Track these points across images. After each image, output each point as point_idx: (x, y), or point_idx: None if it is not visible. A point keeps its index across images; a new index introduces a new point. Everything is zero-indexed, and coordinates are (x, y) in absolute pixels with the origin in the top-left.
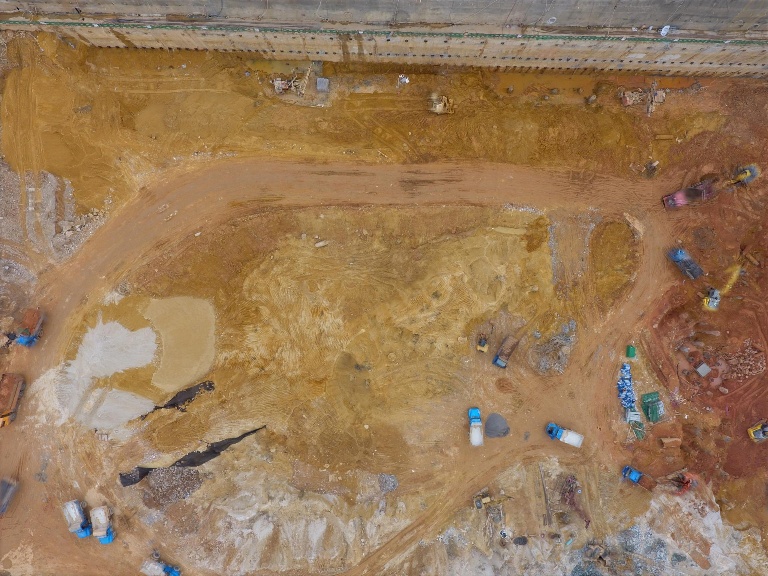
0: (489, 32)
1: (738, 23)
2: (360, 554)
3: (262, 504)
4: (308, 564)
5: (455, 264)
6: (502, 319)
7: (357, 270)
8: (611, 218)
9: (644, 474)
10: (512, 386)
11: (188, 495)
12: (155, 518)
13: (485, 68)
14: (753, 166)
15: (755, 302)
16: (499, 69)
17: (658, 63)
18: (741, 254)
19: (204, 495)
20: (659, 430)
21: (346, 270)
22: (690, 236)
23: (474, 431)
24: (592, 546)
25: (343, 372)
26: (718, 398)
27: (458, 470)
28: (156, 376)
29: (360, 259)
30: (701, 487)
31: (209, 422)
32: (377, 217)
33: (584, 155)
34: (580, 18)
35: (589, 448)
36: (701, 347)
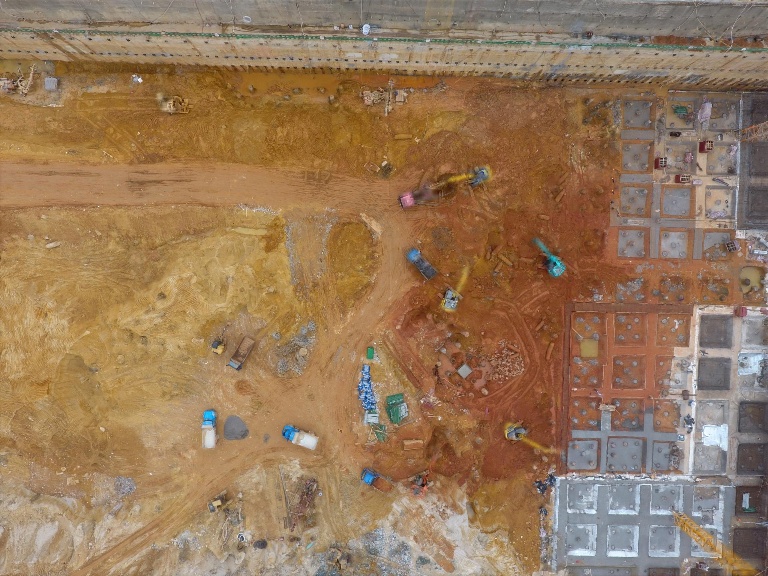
0: (189, 31)
1: (434, 22)
2: (84, 558)
3: None
4: (28, 568)
5: (186, 265)
6: (241, 320)
7: (92, 271)
8: (348, 218)
9: (379, 477)
10: (251, 388)
11: None
12: None
13: (222, 67)
14: (489, 166)
15: (506, 303)
16: (238, 68)
17: (385, 62)
18: (491, 255)
19: None
20: (405, 432)
21: (81, 271)
22: (429, 236)
23: (208, 433)
24: (333, 549)
25: (75, 374)
26: (479, 400)
27: (196, 473)
28: None
29: (95, 260)
30: (445, 489)
31: None
32: (105, 218)
33: (320, 155)
34: (273, 17)
35: (330, 450)
36: (463, 348)
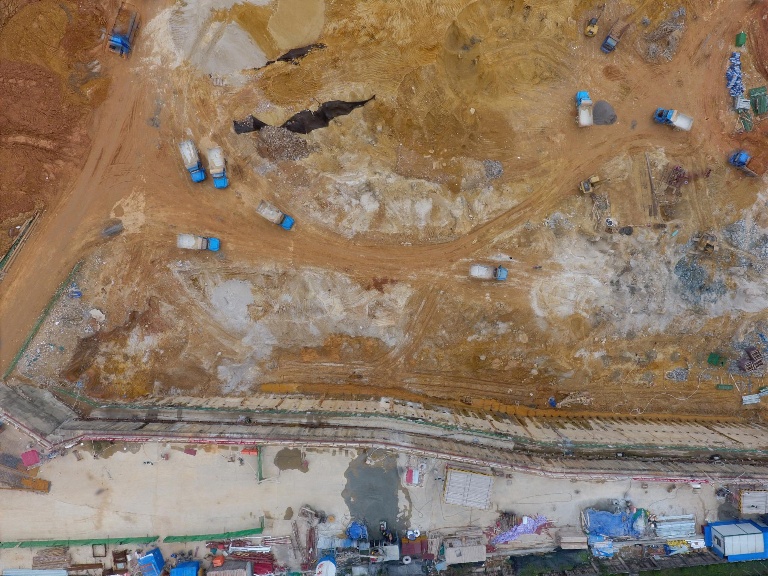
0: None
1: None
2: (469, 225)
3: (370, 176)
4: (418, 231)
5: None
6: (610, 6)
7: None
8: None
9: None
10: (620, 73)
11: (298, 158)
12: (269, 168)
13: None
14: None
15: None
16: None
17: None
18: None
19: (313, 163)
20: (766, 126)
21: None
22: None
23: (583, 113)
24: (697, 238)
25: (451, 51)
26: None
27: (564, 158)
28: (272, 20)
29: None
30: None
31: (321, 80)
32: None
33: None
34: None
35: (696, 139)
36: None
